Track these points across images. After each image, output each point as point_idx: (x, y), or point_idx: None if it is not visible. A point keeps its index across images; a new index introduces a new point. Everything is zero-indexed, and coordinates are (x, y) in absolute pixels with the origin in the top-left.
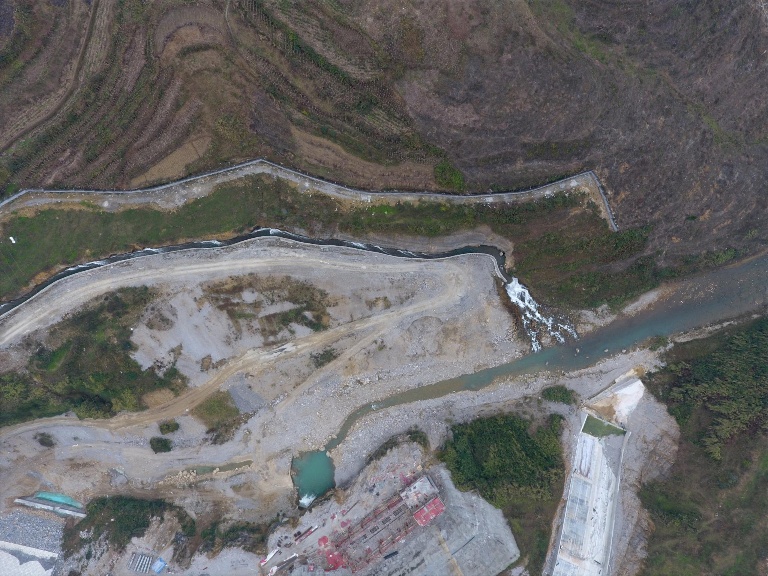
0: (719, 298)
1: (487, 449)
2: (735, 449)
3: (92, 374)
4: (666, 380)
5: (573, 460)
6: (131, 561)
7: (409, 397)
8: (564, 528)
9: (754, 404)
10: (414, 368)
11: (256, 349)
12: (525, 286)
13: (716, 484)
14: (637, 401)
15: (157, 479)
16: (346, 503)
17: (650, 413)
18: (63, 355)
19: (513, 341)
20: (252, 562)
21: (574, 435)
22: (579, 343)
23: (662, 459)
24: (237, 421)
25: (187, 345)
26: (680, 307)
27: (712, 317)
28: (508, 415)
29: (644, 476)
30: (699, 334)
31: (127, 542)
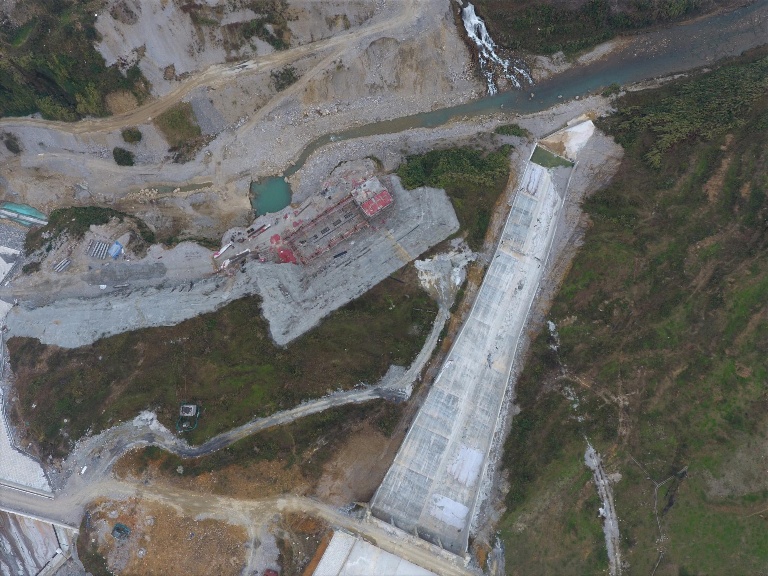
0: (672, 53)
1: (437, 161)
2: (674, 157)
3: (56, 55)
4: (615, 119)
5: (520, 178)
6: (89, 247)
7: (367, 131)
8: (507, 229)
9: (696, 122)
10: (373, 102)
11: (219, 65)
12: (481, 18)
13: (654, 186)
14: (587, 139)
15: (119, 195)
16: (299, 207)
17: (598, 146)
18: (28, 32)
19: (469, 80)
20: (206, 254)
21: (523, 160)
22: (534, 88)
23: (605, 175)
24: (199, 142)
25: (151, 48)
26: (633, 59)
27: (664, 70)
28: (462, 148)
29: (588, 192)
30: (651, 84)
31: (85, 229)
